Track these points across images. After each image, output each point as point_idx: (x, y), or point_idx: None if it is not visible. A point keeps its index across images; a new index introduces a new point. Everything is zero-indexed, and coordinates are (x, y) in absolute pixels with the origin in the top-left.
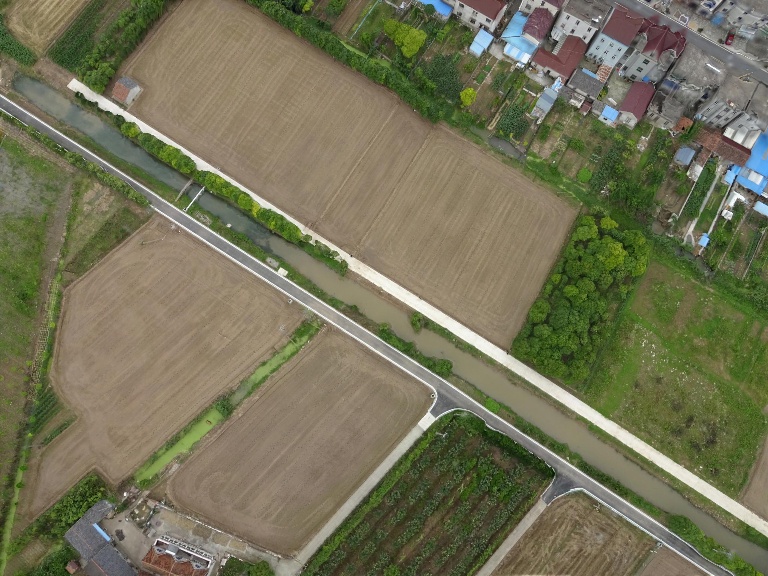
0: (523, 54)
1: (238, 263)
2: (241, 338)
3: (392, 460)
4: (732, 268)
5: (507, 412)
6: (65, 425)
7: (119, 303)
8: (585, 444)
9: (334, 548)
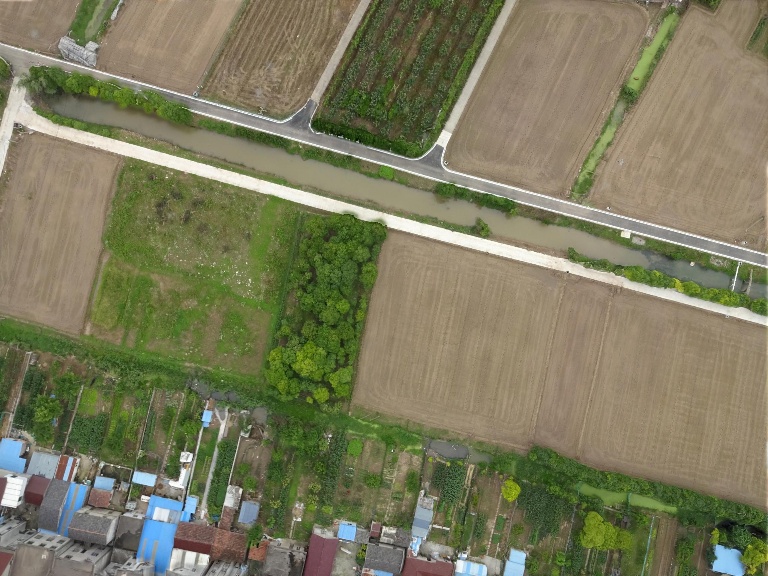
0: (465, 570)
1: (670, 229)
2: (639, 160)
3: (465, 95)
4: (169, 398)
5: (370, 172)
6: (754, 39)
7: (758, 156)
8: (286, 166)
9: (493, 6)
